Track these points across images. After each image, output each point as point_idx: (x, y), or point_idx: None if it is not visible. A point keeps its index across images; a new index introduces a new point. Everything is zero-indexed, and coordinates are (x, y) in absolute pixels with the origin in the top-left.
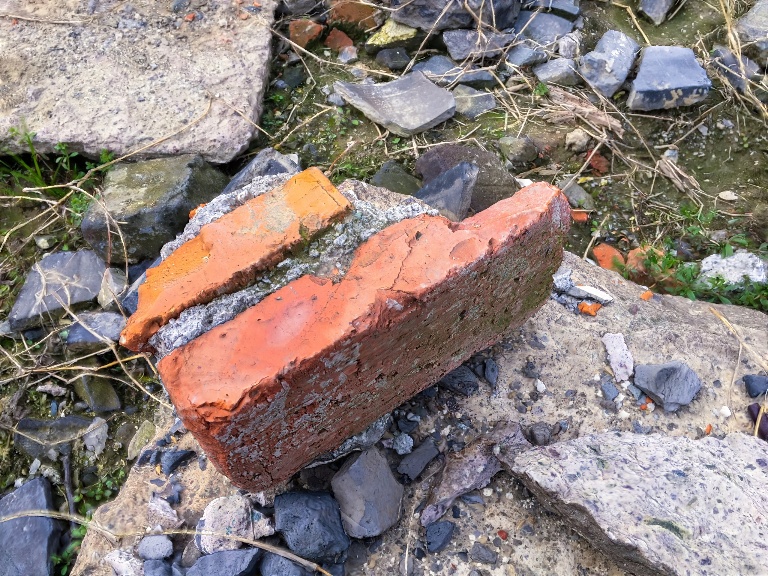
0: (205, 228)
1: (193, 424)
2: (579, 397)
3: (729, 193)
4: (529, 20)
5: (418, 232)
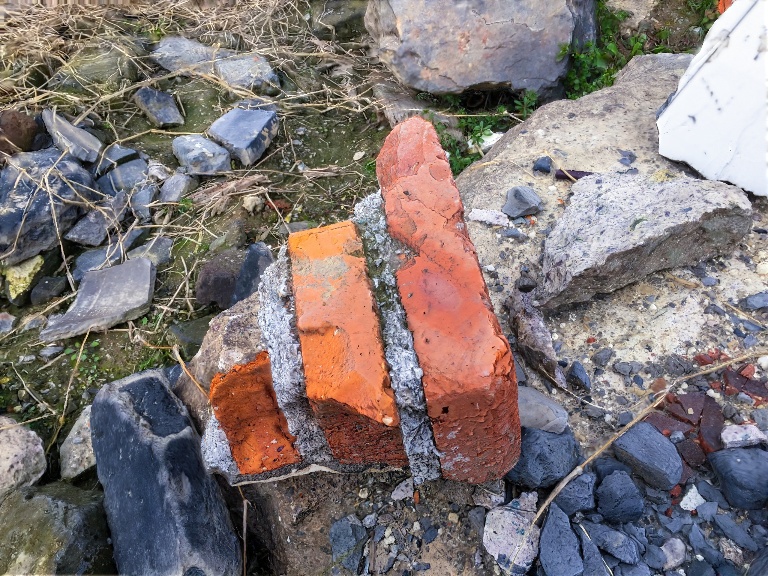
0: (302, 324)
1: (502, 389)
2: (507, 252)
3: (357, 154)
4: (111, 181)
5: (404, 192)
